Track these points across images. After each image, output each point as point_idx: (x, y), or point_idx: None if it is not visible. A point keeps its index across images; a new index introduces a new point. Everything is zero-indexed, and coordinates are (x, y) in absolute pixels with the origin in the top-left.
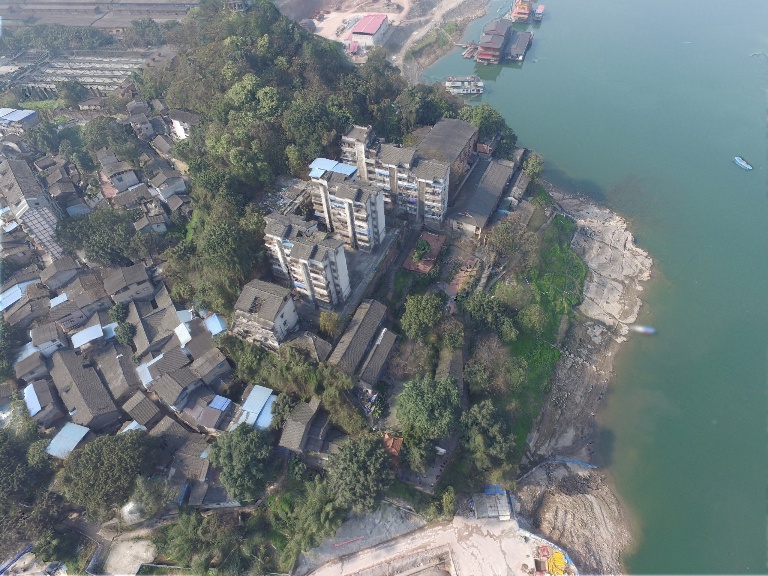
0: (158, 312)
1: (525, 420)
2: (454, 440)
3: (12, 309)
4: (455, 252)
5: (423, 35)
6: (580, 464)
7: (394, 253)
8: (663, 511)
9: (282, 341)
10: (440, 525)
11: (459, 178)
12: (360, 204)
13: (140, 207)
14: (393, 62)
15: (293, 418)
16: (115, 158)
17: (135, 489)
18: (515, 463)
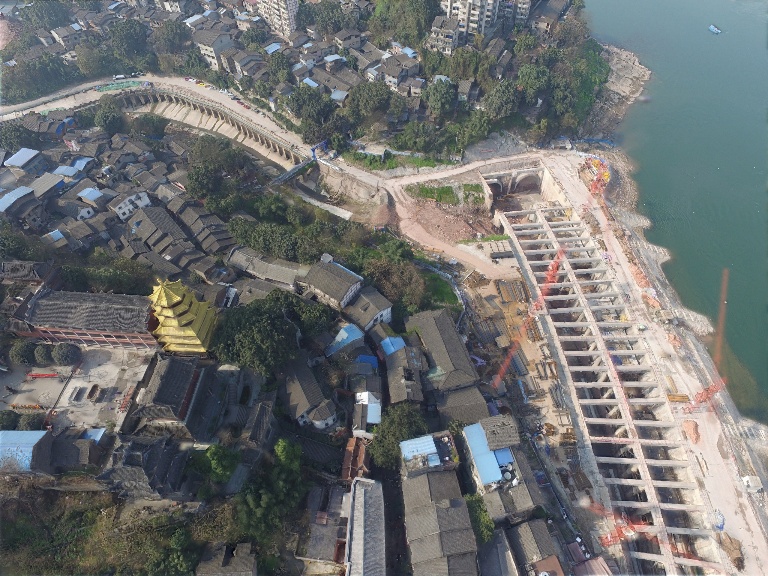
0: (368, 52)
1: None
2: (544, 104)
3: None
4: None
5: None
6: (607, 143)
7: (501, 31)
8: (652, 162)
9: (453, 50)
10: (534, 152)
11: (534, 3)
12: None
13: (341, 6)
14: None
15: None
16: None
17: (391, 100)
18: (576, 116)
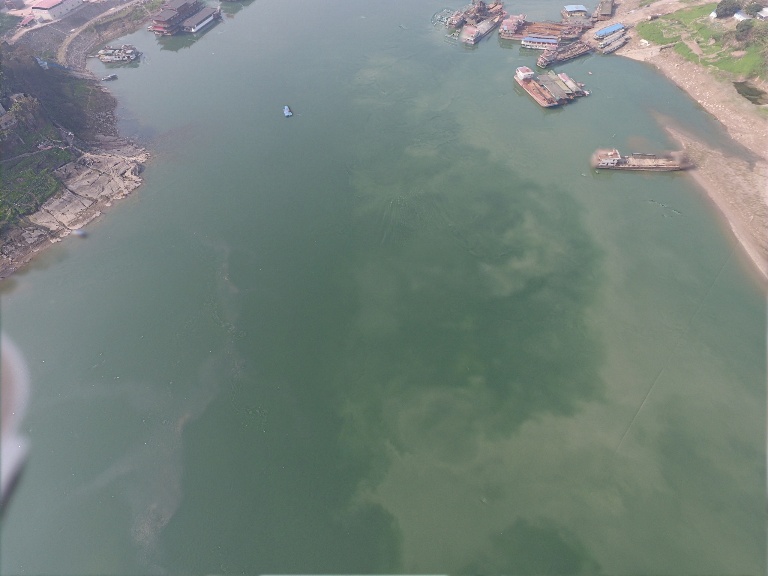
0: None
1: None
2: None
3: None
4: None
5: (116, 11)
6: None
7: None
8: None
9: None
10: None
11: None
12: None
13: None
14: (68, 34)
15: None
16: None
17: None
18: None
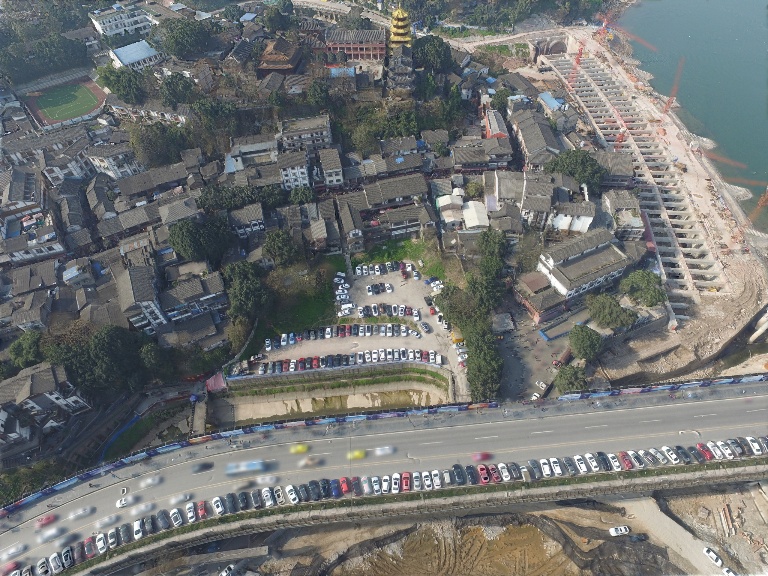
0: None
1: (590, 10)
2: None
3: None
4: None
5: None
6: (611, 26)
7: None
8: None
9: None
10: (561, 28)
11: None
12: None
13: None
14: None
15: None
16: None
17: None
18: None
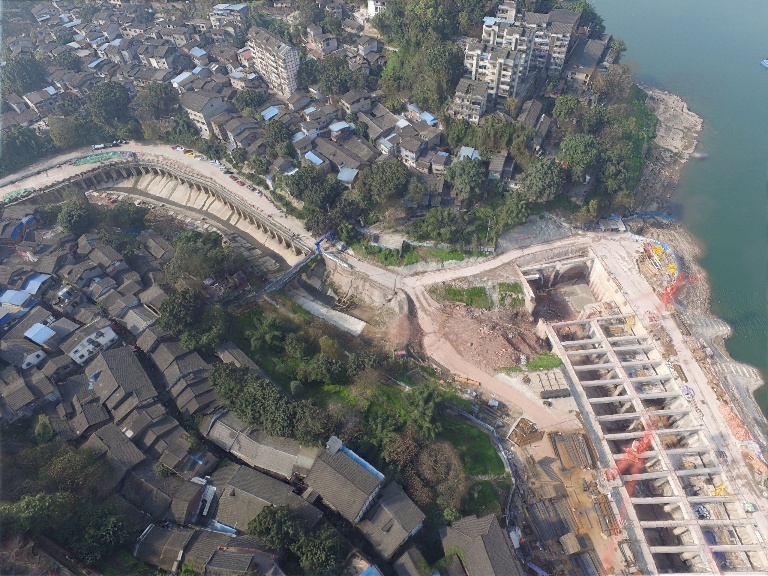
0: (379, 117)
1: None
2: (591, 179)
3: None
4: (571, 93)
5: None
6: (664, 217)
7: (533, 86)
8: (720, 240)
9: (480, 118)
10: (580, 235)
11: None
12: (524, 39)
13: (348, 60)
14: None
15: (496, 156)
16: (321, 31)
17: (409, 185)
18: None
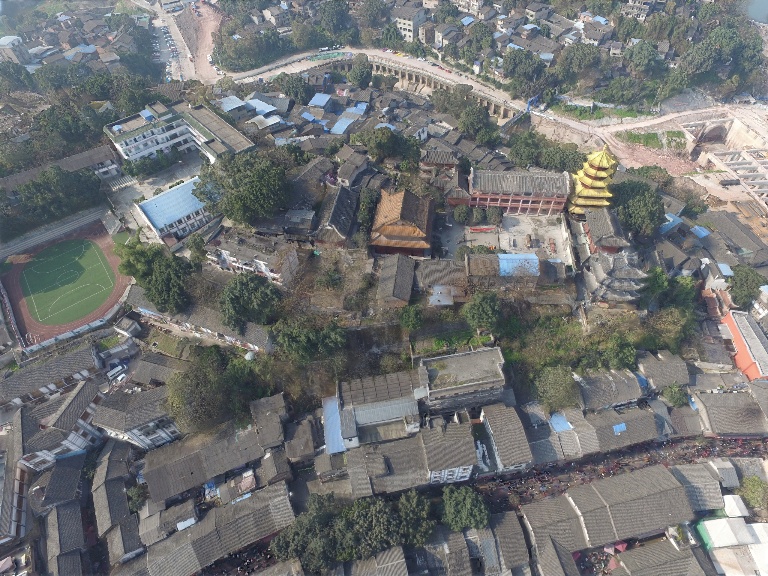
0: (557, 22)
1: None
2: (731, 63)
3: (471, 25)
4: (699, 11)
5: None
6: None
7: None
8: None
9: None
10: (720, 106)
11: None
12: None
13: None
14: None
15: None
16: None
17: (602, 58)
18: (761, 73)
